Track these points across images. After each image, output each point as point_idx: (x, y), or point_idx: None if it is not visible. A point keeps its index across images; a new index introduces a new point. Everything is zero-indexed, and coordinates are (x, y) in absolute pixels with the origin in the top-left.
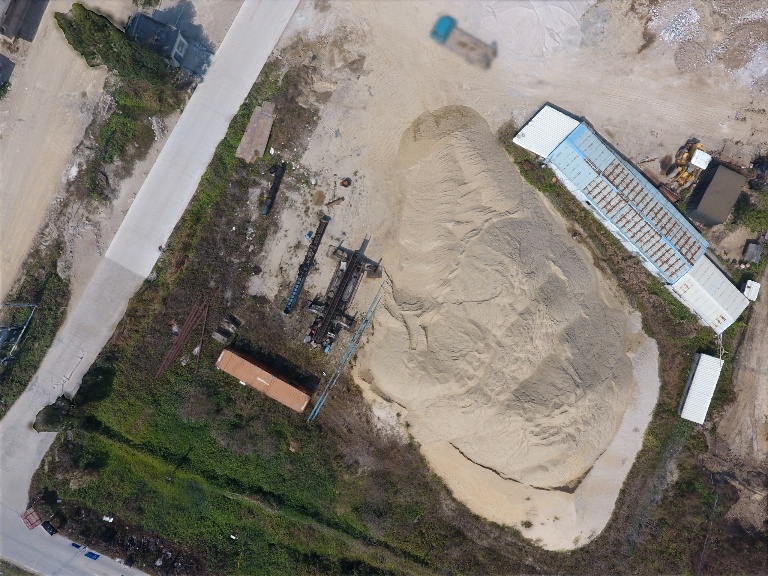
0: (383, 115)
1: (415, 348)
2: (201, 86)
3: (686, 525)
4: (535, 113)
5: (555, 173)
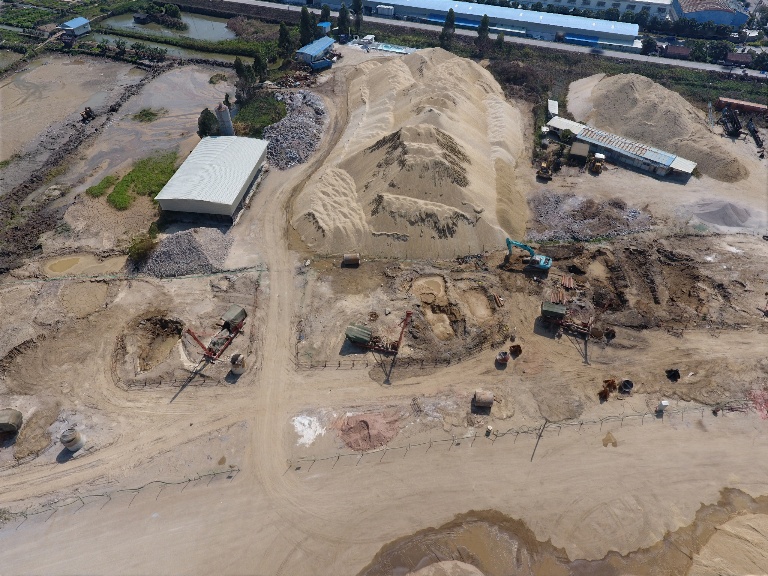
0: (767, 177)
1: None
2: None
3: None
4: (688, 181)
5: None
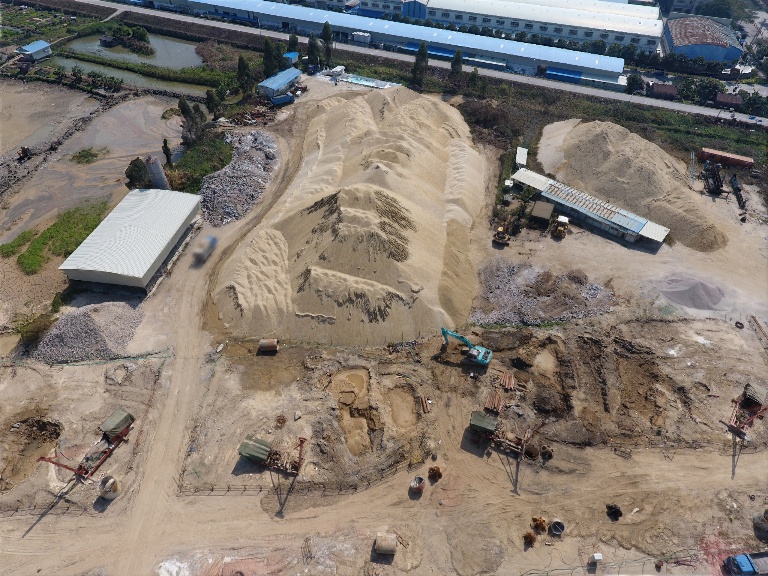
0: None
1: None
2: None
3: None
4: (659, 250)
5: None
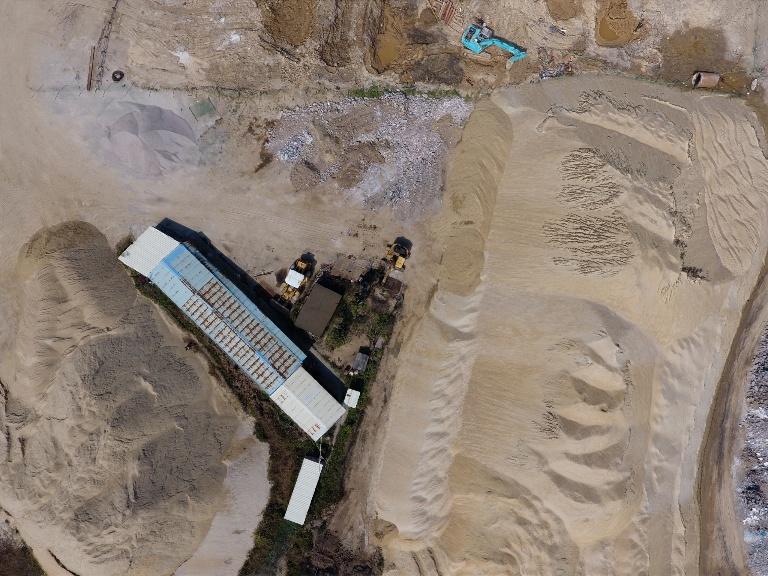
0: (1, 230)
1: (11, 460)
2: None
3: None
4: None
5: None
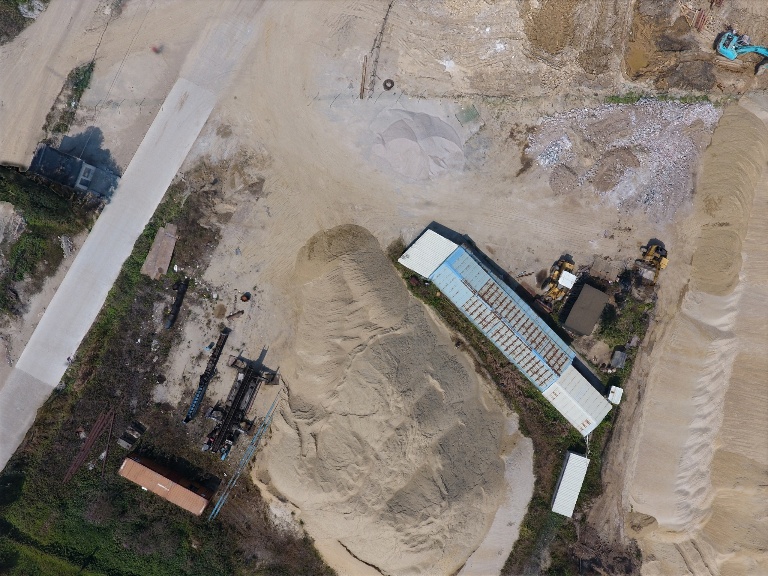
0: (281, 234)
1: (305, 455)
2: (108, 207)
3: None
4: (422, 232)
5: None
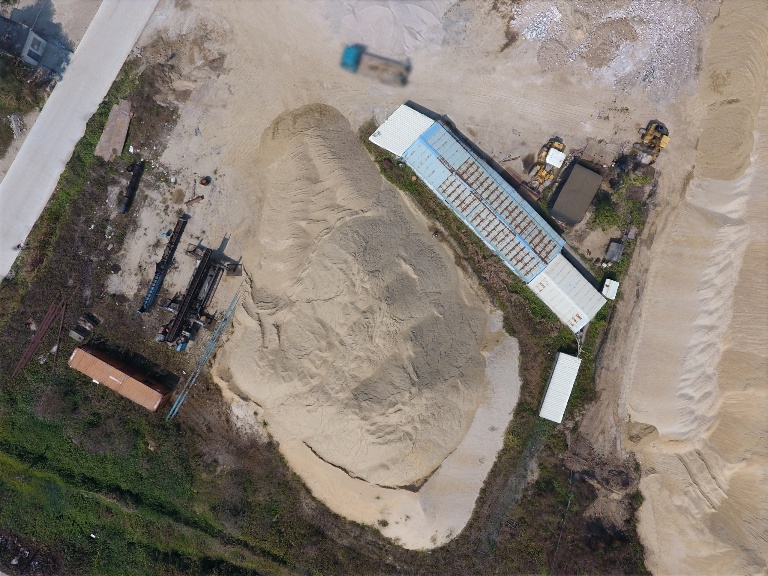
0: (243, 113)
1: (267, 347)
2: (60, 84)
3: (542, 524)
4: None
5: (415, 172)
